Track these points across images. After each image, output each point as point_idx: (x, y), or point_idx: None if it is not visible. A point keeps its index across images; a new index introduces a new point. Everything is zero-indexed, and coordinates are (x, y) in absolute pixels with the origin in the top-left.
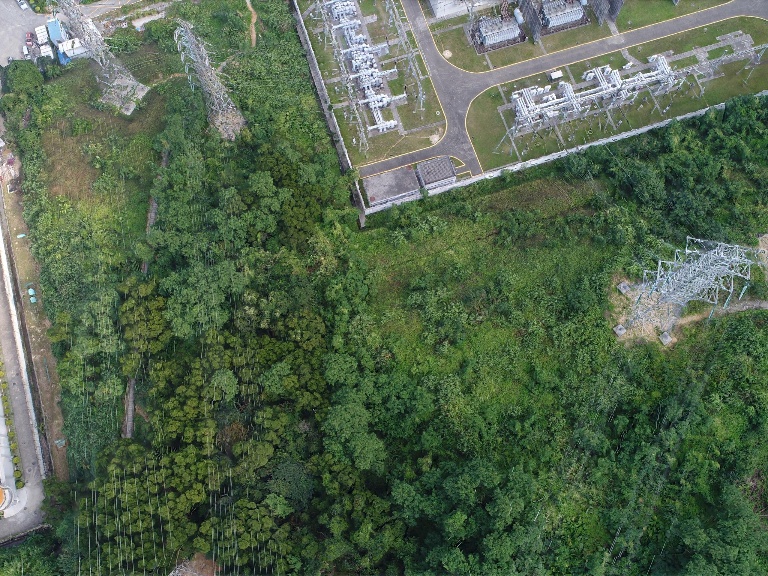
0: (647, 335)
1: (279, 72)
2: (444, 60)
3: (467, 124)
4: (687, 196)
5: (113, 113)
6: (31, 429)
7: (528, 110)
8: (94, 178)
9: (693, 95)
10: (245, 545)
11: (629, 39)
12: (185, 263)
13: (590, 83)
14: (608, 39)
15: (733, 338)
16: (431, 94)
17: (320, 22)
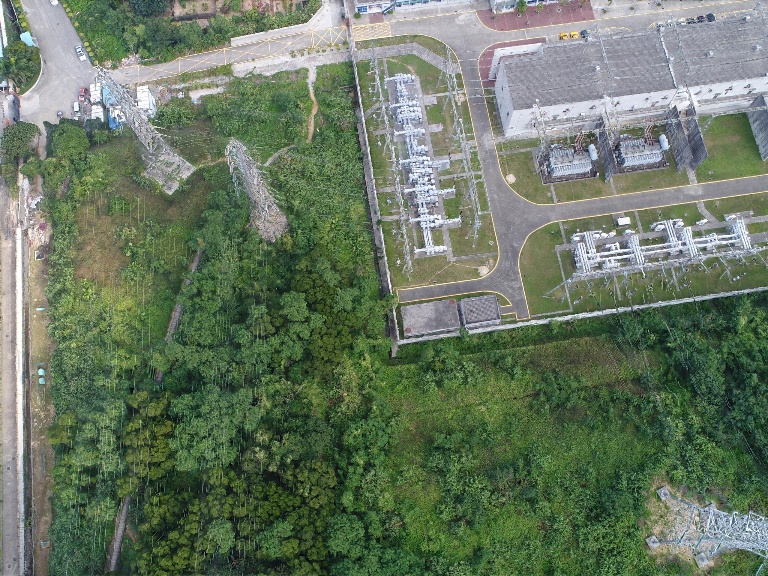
0: (682, 553)
1: (331, 174)
2: (506, 185)
3: (520, 260)
4: (748, 399)
5: (154, 191)
6: (18, 522)
7: (588, 257)
8: (123, 265)
9: None
10: None
11: (707, 191)
12: (201, 379)
13: (658, 234)
14: (685, 188)
15: None
16: (487, 220)
17: (382, 123)
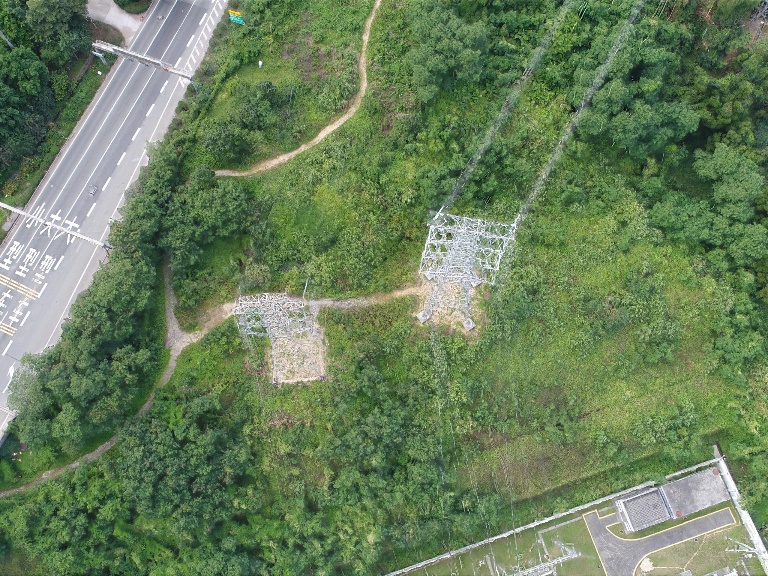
0: None
1: None
2: None
3: None
4: None
5: None
6: None
7: None
8: None
9: None
10: None
11: None
12: None
13: None
14: None
15: (371, 266)
16: None
17: None
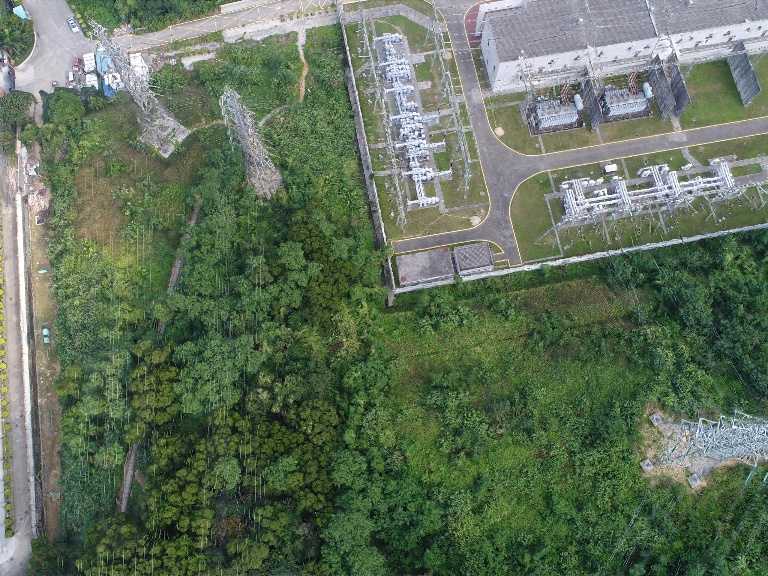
0: (675, 475)
1: (324, 132)
2: (495, 138)
3: (511, 209)
4: (735, 327)
5: (150, 154)
6: (28, 476)
7: (577, 203)
8: (122, 224)
9: (752, 206)
10: None
11: (691, 138)
12: (203, 329)
13: (645, 180)
14: (669, 135)
15: (767, 492)
16: (477, 172)
17: (372, 82)
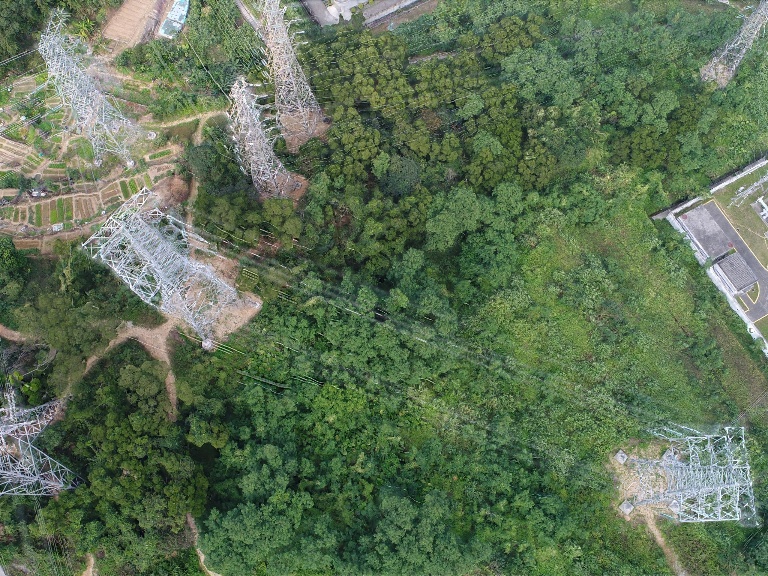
0: (625, 487)
1: None
2: None
3: None
4: None
5: None
6: (398, 4)
7: None
8: None
9: None
10: (346, 138)
11: None
12: None
13: None
14: None
15: None
16: None
17: None
